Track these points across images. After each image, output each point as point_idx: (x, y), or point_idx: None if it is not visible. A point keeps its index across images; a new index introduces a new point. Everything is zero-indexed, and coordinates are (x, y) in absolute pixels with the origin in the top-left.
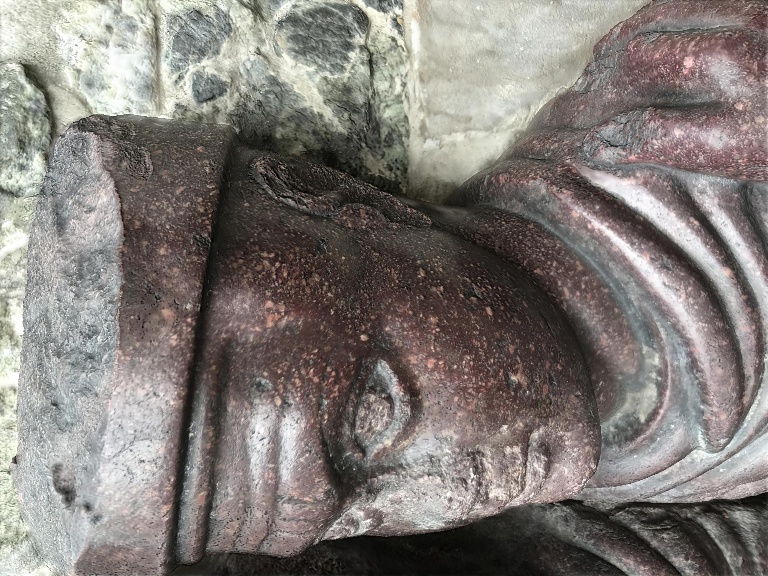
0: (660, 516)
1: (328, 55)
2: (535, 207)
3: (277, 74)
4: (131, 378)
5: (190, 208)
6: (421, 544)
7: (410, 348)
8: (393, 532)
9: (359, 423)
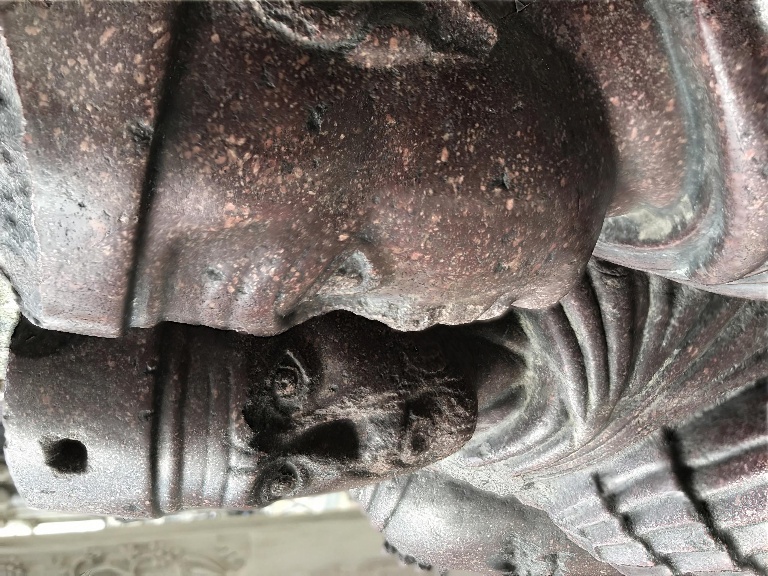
0: None
1: None
2: (667, 3)
3: None
4: (60, 274)
5: (121, 75)
6: None
7: (396, 242)
8: None
9: (320, 292)
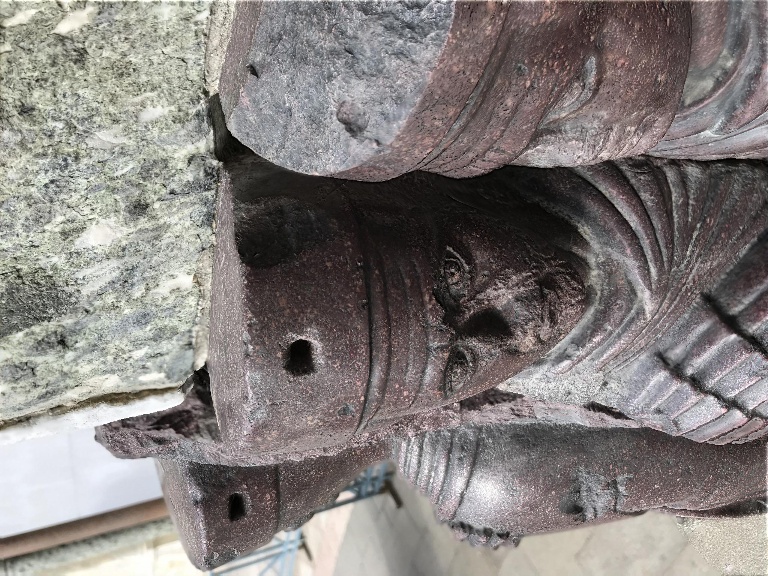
0: (641, 163)
1: None
2: None
3: None
4: (451, 58)
5: None
6: None
7: (613, 49)
8: None
9: (559, 102)
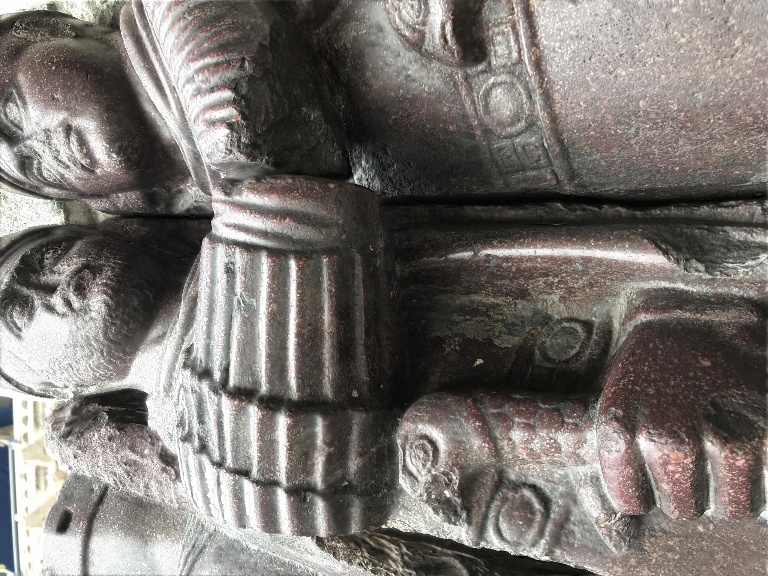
0: None
1: None
2: None
3: None
4: None
5: None
6: None
7: (22, 85)
8: None
9: (9, 115)
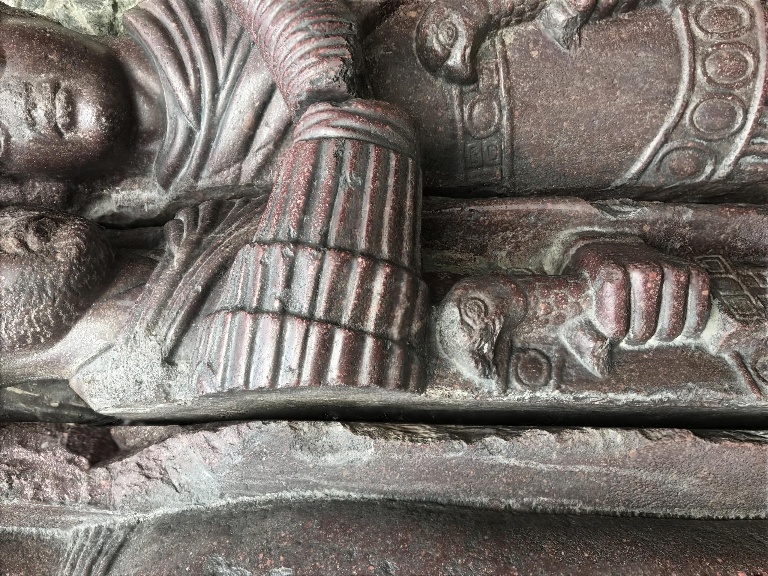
0: None
1: (92, 3)
2: (126, 27)
3: (68, 13)
4: None
5: None
6: (118, 246)
7: (4, 41)
8: (22, 149)
9: None
